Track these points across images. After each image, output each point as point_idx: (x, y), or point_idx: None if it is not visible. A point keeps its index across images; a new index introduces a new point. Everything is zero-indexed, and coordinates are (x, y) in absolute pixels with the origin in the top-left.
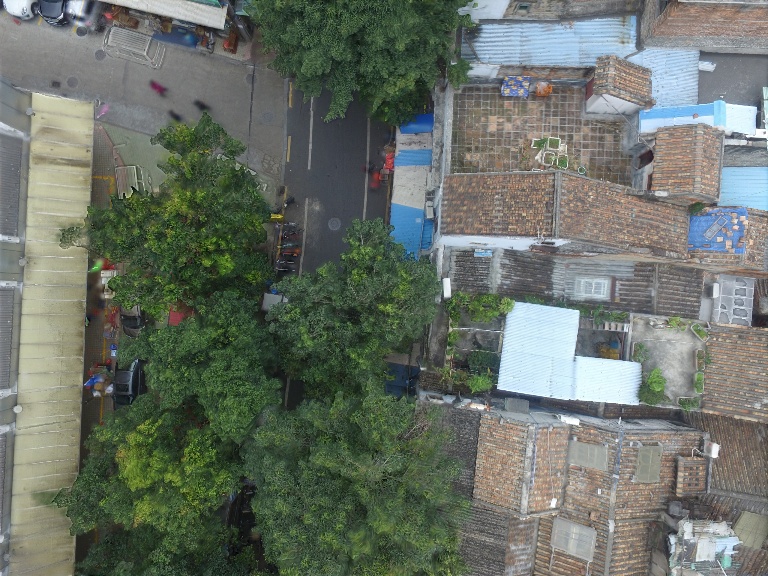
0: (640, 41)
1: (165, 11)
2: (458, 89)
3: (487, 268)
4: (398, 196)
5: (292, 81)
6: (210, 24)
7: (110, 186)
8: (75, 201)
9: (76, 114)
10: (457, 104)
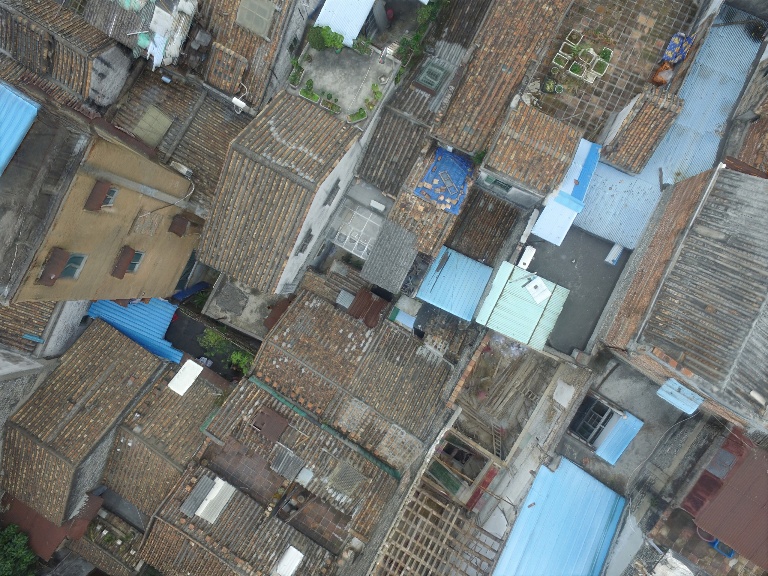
0: None
1: None
2: (699, 1)
3: None
4: None
5: None
6: None
7: None
8: None
9: None
10: None
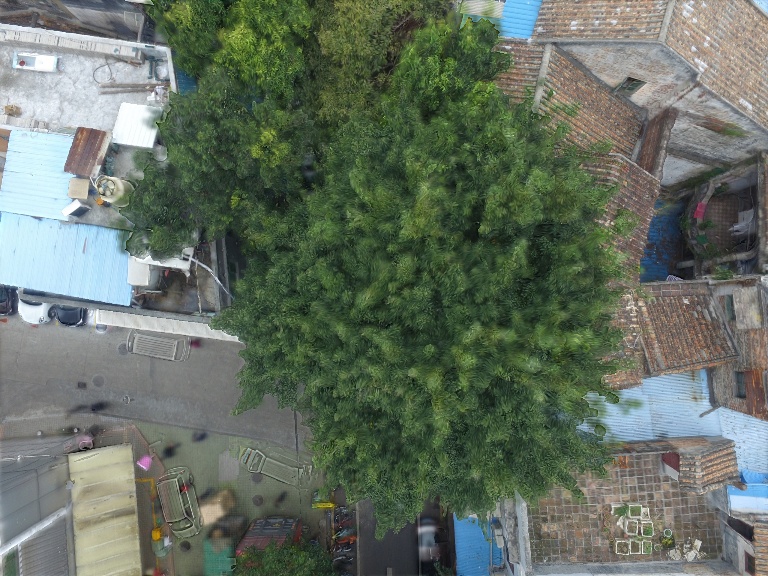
0: (714, 399)
1: (192, 332)
2: None
3: None
4: None
5: None
6: None
7: (151, 491)
8: (124, 553)
9: (114, 461)
10: None
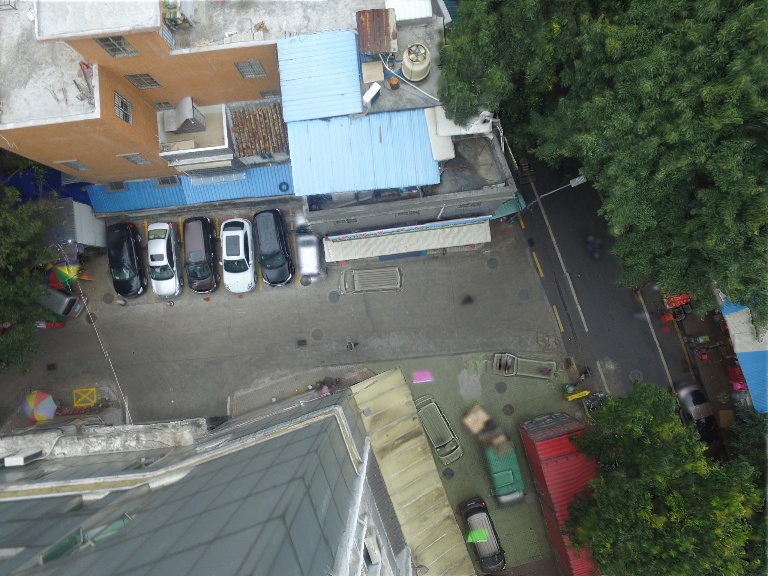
0: None
1: (425, 245)
2: None
3: None
4: (742, 344)
5: (533, 250)
6: (475, 241)
7: None
8: (424, 475)
9: (389, 387)
10: None
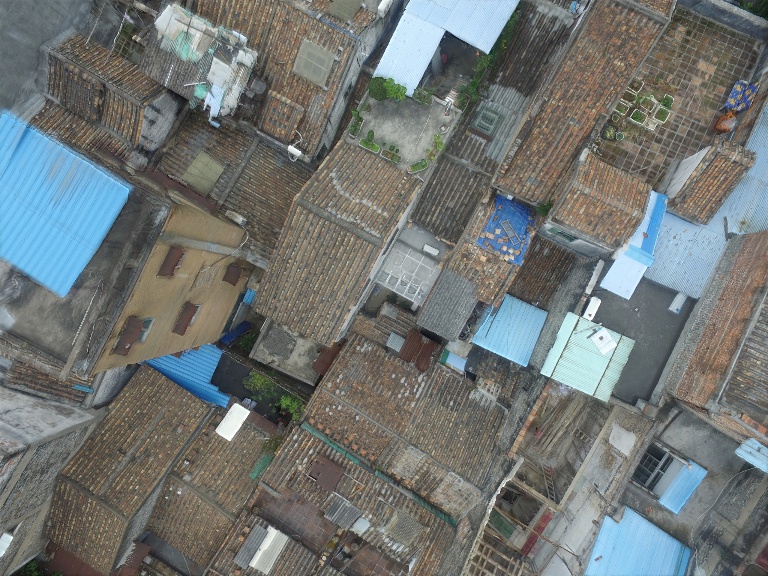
0: None
1: None
2: (759, 47)
3: (558, 3)
4: None
5: None
6: None
7: None
8: None
9: None
10: (743, 40)
